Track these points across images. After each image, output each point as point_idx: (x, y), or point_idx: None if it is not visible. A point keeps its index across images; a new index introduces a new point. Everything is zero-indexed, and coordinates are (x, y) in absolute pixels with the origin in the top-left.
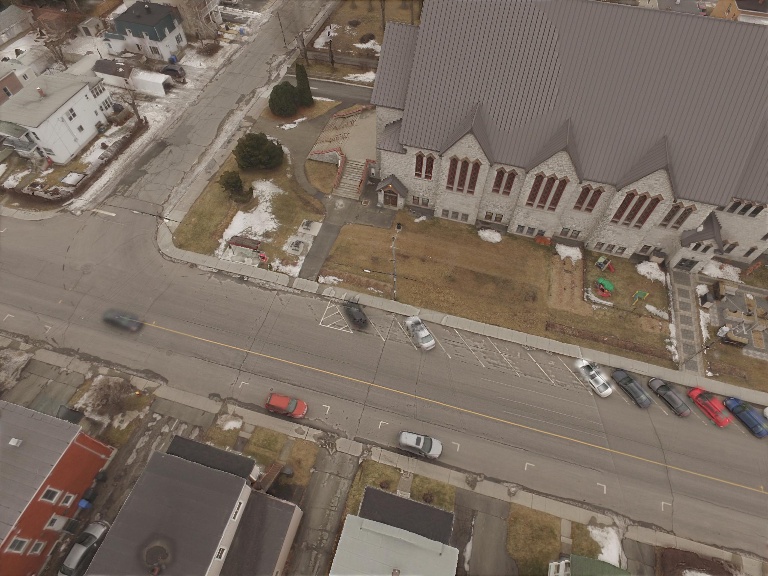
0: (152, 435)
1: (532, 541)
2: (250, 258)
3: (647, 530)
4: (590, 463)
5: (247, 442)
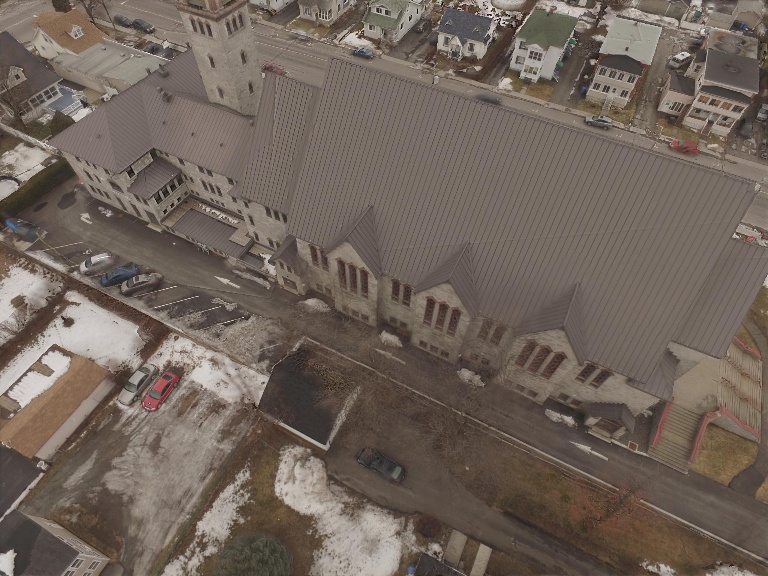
0: (760, 149)
1: (542, 88)
2: (762, 245)
3: (483, 87)
4: (502, 106)
5: (700, 138)
